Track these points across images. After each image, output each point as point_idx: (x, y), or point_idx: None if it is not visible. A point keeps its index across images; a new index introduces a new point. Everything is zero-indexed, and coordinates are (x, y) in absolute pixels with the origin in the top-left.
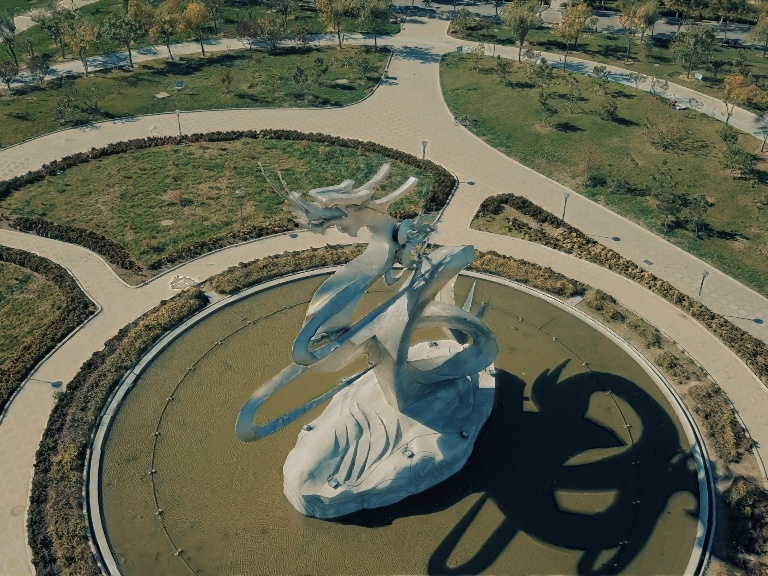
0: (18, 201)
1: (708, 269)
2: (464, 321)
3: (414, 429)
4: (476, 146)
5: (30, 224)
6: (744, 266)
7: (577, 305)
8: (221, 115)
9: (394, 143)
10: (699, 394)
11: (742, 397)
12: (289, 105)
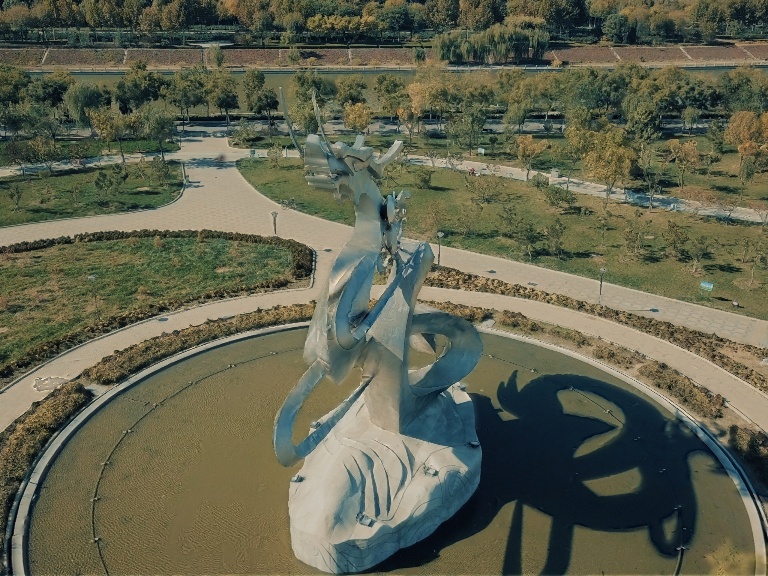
0: None
1: (586, 281)
2: (446, 317)
3: (423, 448)
4: (314, 222)
5: None
6: (613, 273)
7: (493, 326)
8: (17, 230)
9: (229, 229)
10: (651, 371)
11: (685, 367)
12: (95, 213)
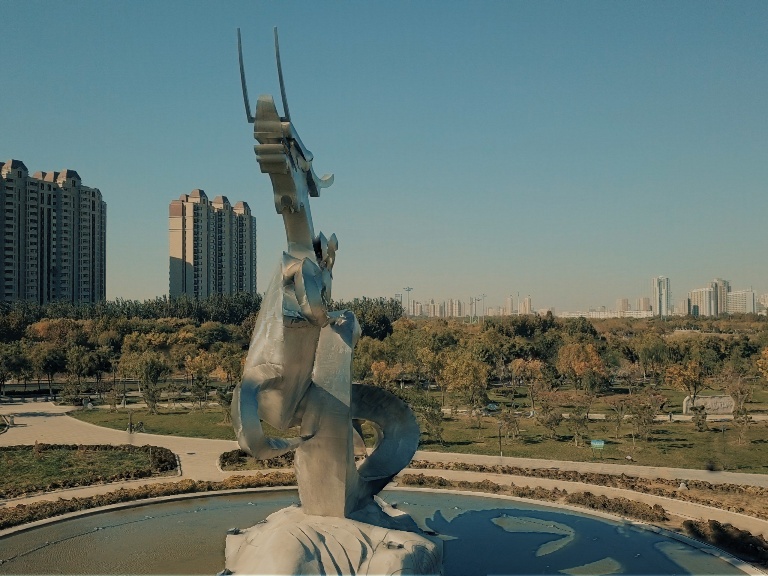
0: None
1: (476, 456)
2: (378, 393)
3: (376, 529)
4: (169, 439)
5: None
6: None
7: (398, 486)
8: None
9: None
10: None
11: (610, 496)
12: None
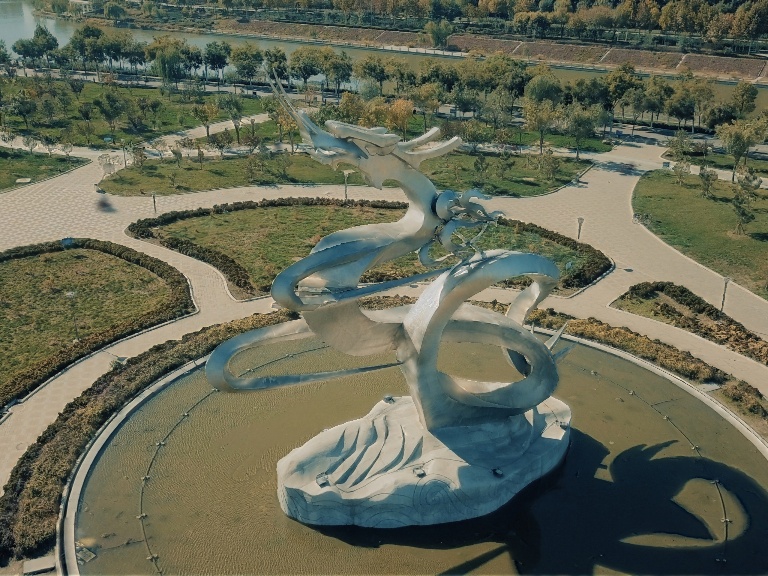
0: (178, 227)
1: None
2: (518, 336)
3: (438, 451)
4: (649, 242)
5: (177, 243)
6: None
7: (709, 392)
8: (395, 191)
9: (558, 229)
10: None
11: None
12: None
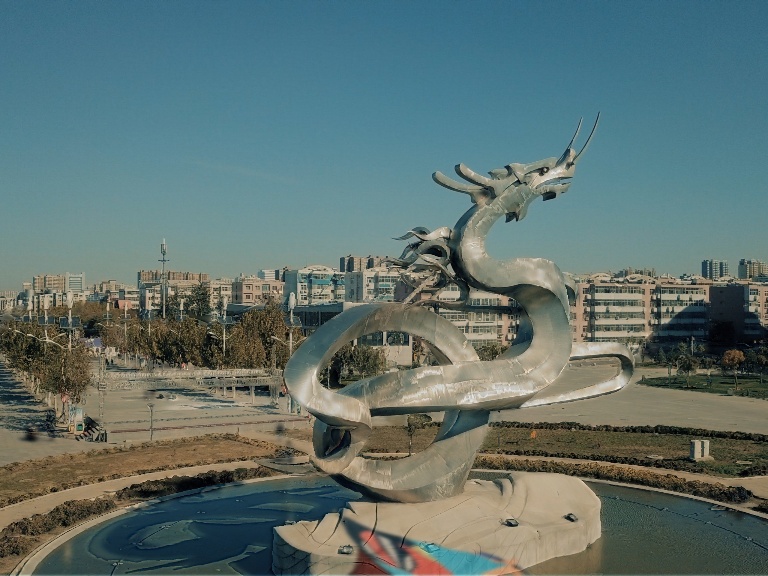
0: None
1: None
2: None
3: None
4: None
5: None
6: None
7: None
8: None
9: None
10: None
11: None
12: None
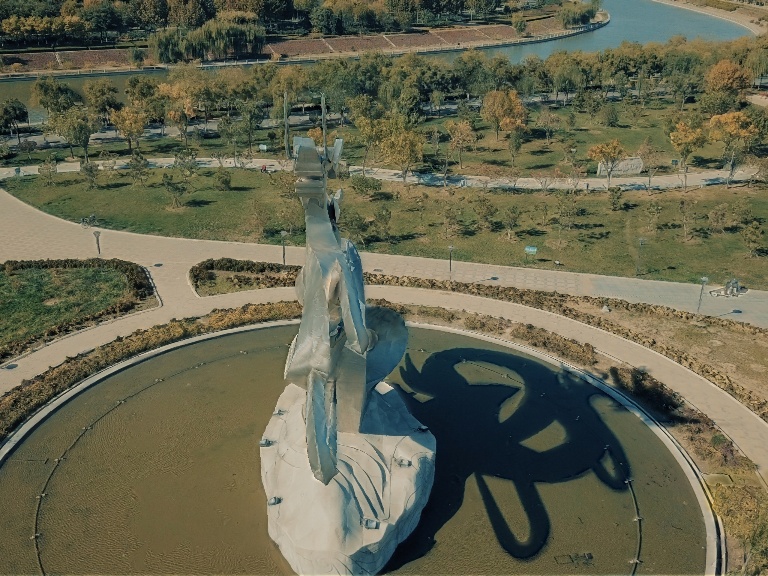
0: None
1: (423, 260)
2: (376, 311)
3: (385, 442)
4: (127, 238)
5: None
6: (444, 250)
7: None
8: None
9: (35, 257)
10: (524, 333)
11: (547, 325)
12: None
